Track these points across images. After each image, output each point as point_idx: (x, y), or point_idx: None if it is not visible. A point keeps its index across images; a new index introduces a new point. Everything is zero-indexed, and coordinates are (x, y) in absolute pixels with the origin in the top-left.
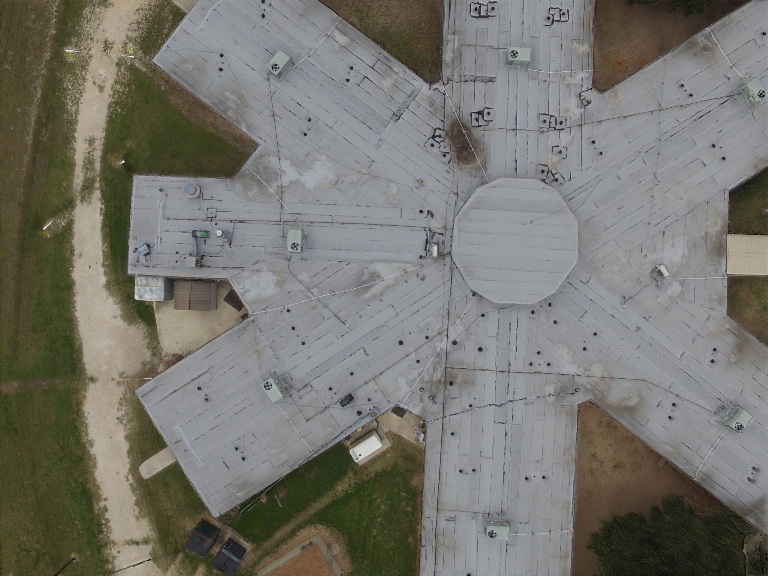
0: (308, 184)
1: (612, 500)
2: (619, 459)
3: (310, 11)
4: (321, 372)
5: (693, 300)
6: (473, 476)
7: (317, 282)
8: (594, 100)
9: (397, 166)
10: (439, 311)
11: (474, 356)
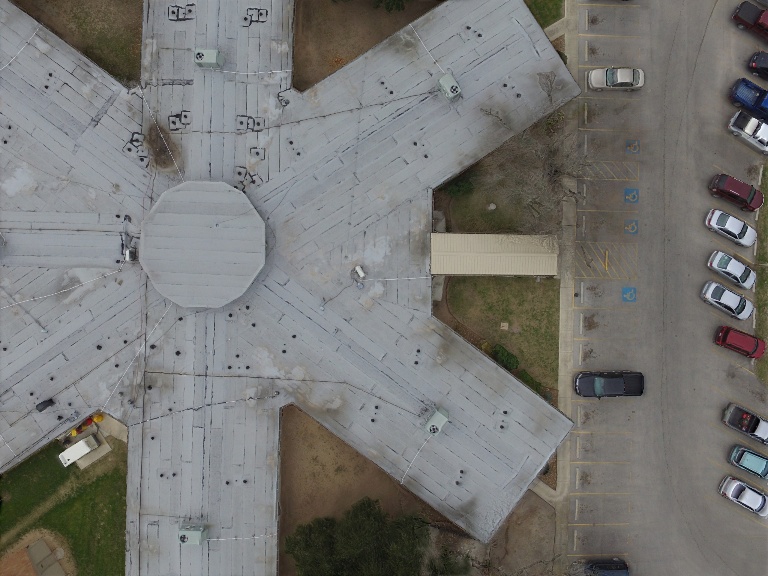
0: (9, 191)
1: (324, 504)
2: (341, 463)
3: (12, 19)
4: (21, 377)
5: (396, 301)
6: (175, 480)
7: (18, 288)
8: (293, 100)
9: (94, 171)
10: (137, 315)
11: (173, 360)
